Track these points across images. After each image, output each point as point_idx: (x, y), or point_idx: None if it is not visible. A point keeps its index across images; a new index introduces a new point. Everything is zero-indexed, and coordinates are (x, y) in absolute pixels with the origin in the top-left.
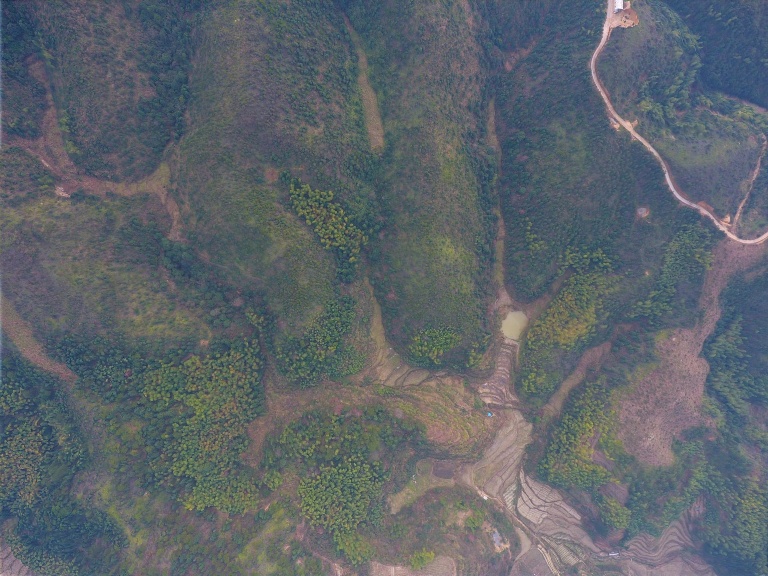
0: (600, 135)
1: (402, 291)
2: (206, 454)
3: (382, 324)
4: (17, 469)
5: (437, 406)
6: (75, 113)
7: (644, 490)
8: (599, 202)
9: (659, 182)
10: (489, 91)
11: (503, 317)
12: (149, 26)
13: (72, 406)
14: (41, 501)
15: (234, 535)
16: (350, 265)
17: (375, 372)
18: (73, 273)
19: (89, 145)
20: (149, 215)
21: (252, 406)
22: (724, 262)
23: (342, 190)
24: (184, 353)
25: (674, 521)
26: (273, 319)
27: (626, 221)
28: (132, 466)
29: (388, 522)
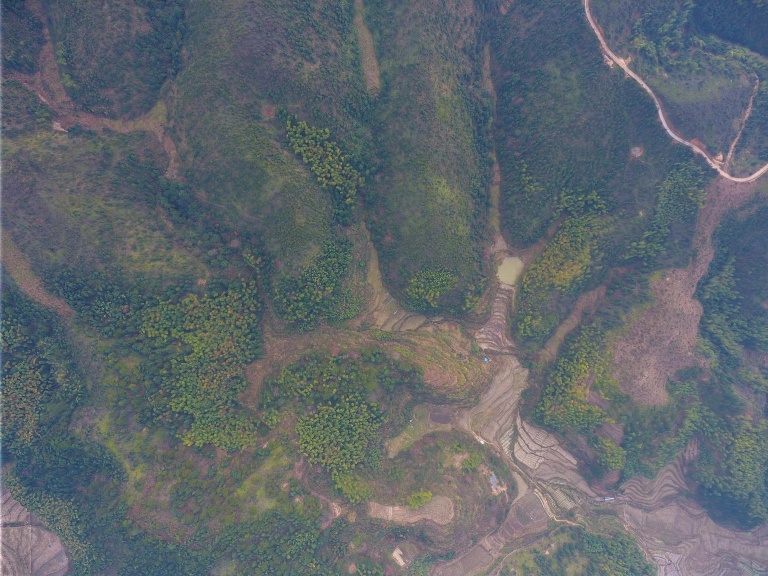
0: (594, 72)
1: (399, 233)
2: (204, 392)
3: (379, 269)
4: (16, 408)
5: (434, 350)
6: (72, 45)
7: (639, 430)
8: (593, 142)
9: (652, 119)
10: (484, 34)
11: (499, 262)
12: None
13: (70, 341)
14: (40, 440)
15: (233, 471)
16: (347, 207)
17: (372, 317)
18: (71, 205)
19: (86, 79)
20: (146, 151)
21: (250, 346)
22: (717, 200)
23: (338, 128)
24: (182, 291)
25: (669, 465)
26: (270, 260)
27: (620, 161)
28: (131, 400)
29: (386, 465)
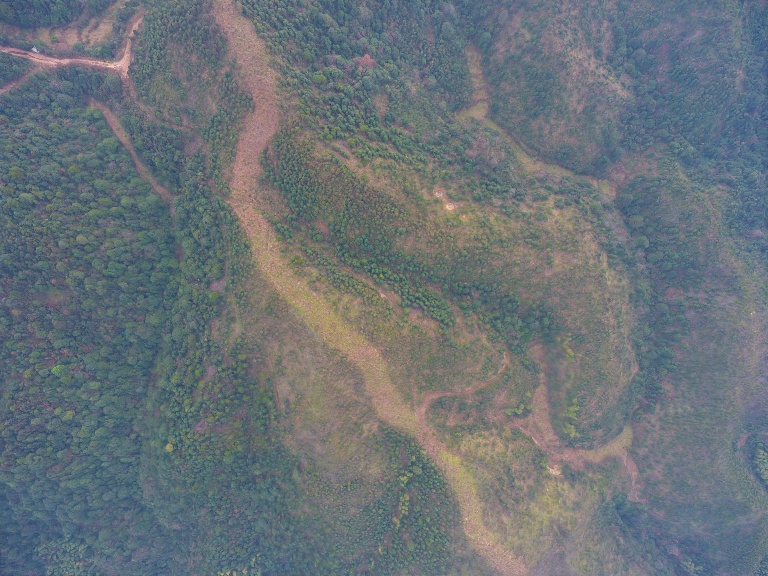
0: None
1: None
2: None
3: None
4: None
5: None
6: (585, 401)
7: None
8: None
9: None
10: None
11: None
12: (639, 305)
13: None
14: None
15: None
16: None
17: None
18: (580, 560)
19: (585, 426)
20: (624, 484)
21: None
22: None
23: None
24: None
25: None
26: (711, 568)
27: None
28: None
29: None
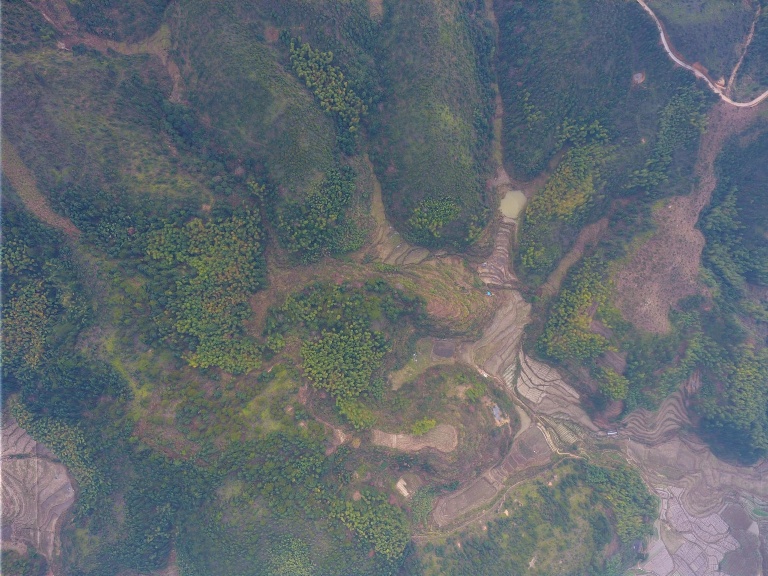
0: None
1: (402, 162)
2: (209, 315)
3: (382, 202)
4: (22, 332)
5: (437, 282)
6: None
7: (641, 359)
8: (596, 68)
9: (655, 42)
10: None
11: (502, 196)
12: None
13: (76, 261)
14: (46, 363)
15: (238, 392)
16: (350, 135)
17: (375, 250)
18: (76, 122)
19: None
20: (150, 73)
21: (254, 273)
22: (719, 125)
23: (342, 52)
24: (186, 214)
25: (671, 399)
26: (274, 187)
27: (622, 89)
28: (136, 320)
29: (389, 397)
